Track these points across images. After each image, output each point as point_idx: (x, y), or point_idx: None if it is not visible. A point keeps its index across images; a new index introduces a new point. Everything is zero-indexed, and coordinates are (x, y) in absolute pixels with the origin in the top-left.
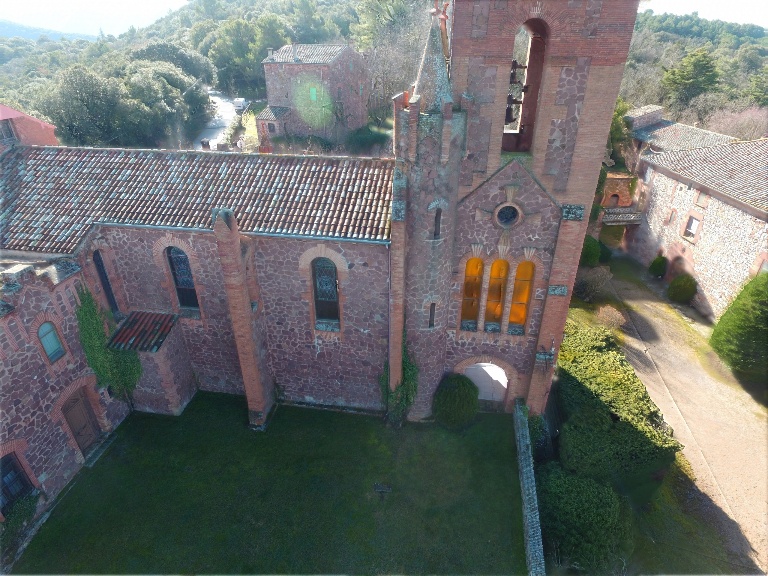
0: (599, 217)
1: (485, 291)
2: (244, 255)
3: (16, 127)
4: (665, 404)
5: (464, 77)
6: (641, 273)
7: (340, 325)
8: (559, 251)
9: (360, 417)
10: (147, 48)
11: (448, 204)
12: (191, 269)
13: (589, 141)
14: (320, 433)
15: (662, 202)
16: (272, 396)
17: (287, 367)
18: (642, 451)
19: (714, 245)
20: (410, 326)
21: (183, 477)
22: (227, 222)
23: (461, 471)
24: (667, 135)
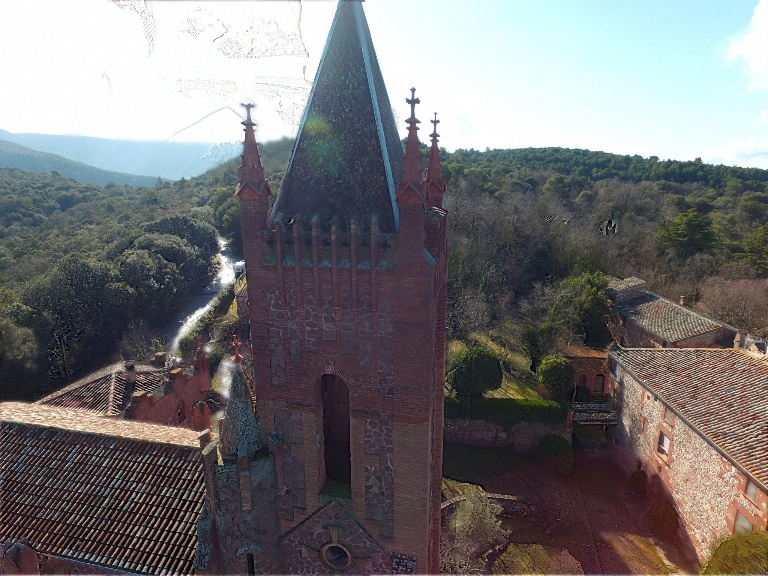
0: (568, 417)
1: None
2: None
3: None
4: None
5: (271, 418)
6: (621, 485)
7: None
8: None
9: None
10: (160, 221)
11: (261, 547)
12: None
13: (408, 492)
14: None
15: (633, 406)
16: None
17: None
18: None
19: (687, 474)
20: None
21: None
22: (16, 561)
23: None
24: (650, 312)
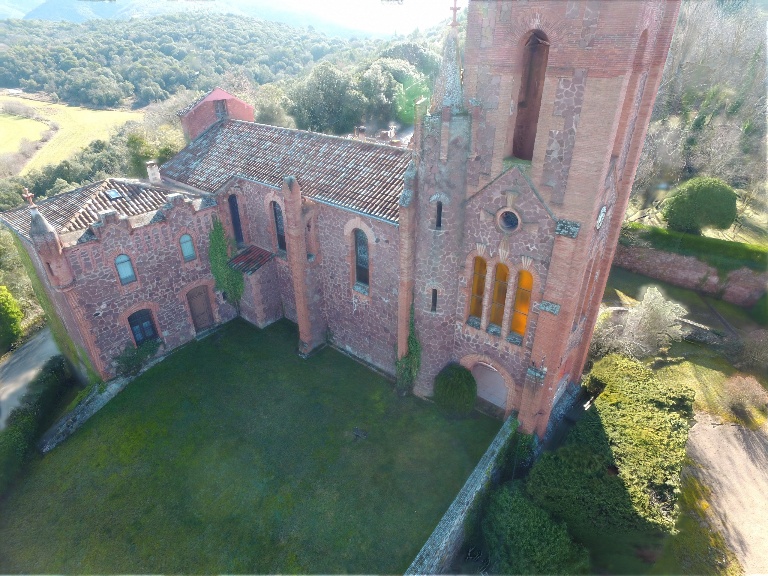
0: None
1: (487, 291)
2: (304, 215)
3: (227, 105)
4: (764, 512)
5: (474, 84)
6: None
7: (369, 290)
8: (553, 266)
9: (378, 376)
10: (394, 48)
11: (449, 199)
12: (283, 220)
13: (586, 156)
14: (341, 376)
15: None
16: (323, 336)
17: (335, 316)
18: (614, 510)
19: None
20: (417, 305)
21: (240, 367)
22: (290, 186)
23: (429, 449)
24: None
